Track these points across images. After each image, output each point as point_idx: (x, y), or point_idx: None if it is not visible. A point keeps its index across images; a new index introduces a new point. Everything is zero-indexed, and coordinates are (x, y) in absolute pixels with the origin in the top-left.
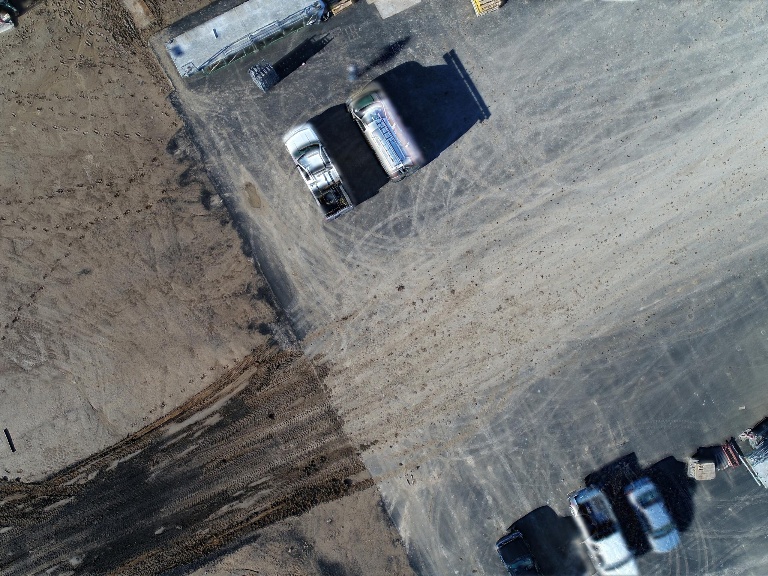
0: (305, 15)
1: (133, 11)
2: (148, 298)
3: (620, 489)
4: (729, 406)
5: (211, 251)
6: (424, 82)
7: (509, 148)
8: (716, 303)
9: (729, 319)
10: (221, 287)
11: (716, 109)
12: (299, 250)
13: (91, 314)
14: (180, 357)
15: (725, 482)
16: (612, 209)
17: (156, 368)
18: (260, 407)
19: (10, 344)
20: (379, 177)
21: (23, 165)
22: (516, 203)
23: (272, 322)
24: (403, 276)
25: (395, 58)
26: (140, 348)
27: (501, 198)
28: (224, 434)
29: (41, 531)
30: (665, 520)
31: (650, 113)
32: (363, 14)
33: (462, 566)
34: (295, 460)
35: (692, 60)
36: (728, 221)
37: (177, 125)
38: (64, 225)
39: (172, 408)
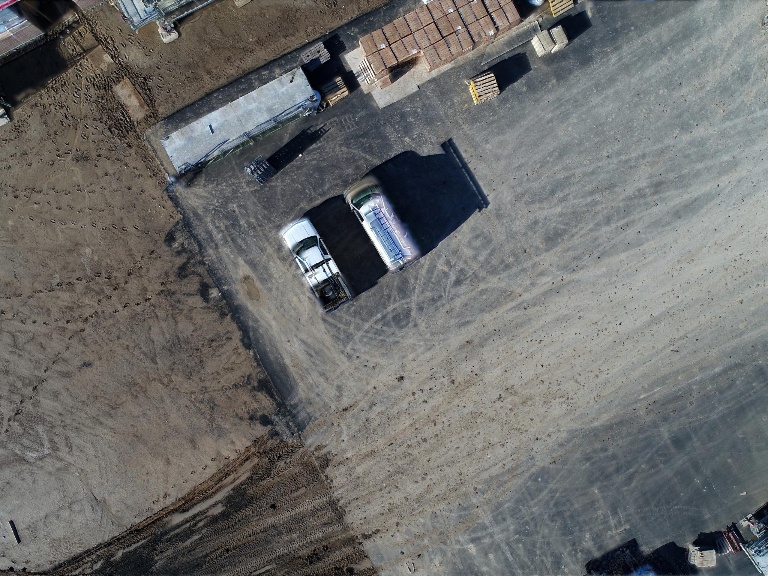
0: (301, 110)
1: (128, 104)
2: (149, 390)
3: (621, 575)
4: (730, 492)
5: (211, 343)
6: (422, 172)
7: (508, 237)
8: (717, 390)
9: (730, 406)
10: (221, 379)
11: (718, 195)
12: (298, 342)
13: (92, 407)
14: (181, 448)
15: (726, 567)
16: (612, 297)
17: (158, 459)
18: (262, 497)
19: (13, 437)
20: (378, 268)
21: (22, 259)
22: (516, 292)
23: (272, 413)
24: (403, 367)
25: (393, 148)
26: (142, 440)
27: (500, 287)
28: (226, 524)
29: None
30: None
31: (651, 200)
32: (360, 104)
33: None
34: (297, 549)
35: (693, 145)
36: (730, 308)
37: (175, 218)
38: (64, 319)
39: (174, 499)
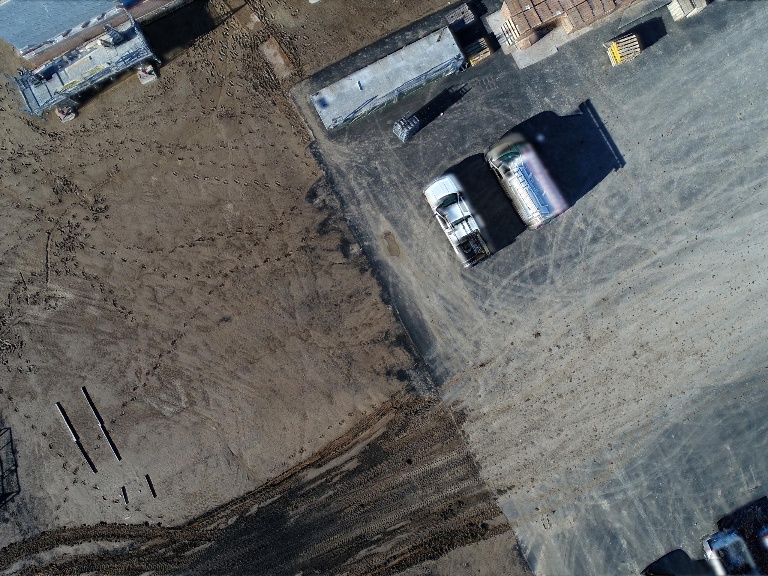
0: (448, 68)
1: (273, 62)
2: (287, 345)
3: (752, 532)
4: None
5: (350, 299)
6: (560, 131)
7: (644, 196)
8: None
9: None
10: (359, 334)
11: None
12: (437, 298)
13: (231, 361)
14: (319, 403)
15: None
16: (745, 256)
17: (295, 414)
18: (398, 453)
19: (151, 391)
20: (516, 225)
21: (164, 214)
22: (651, 251)
23: (410, 369)
24: (540, 323)
25: (532, 108)
26: (279, 394)
27: (636, 246)
28: (362, 479)
29: (182, 575)
30: None
31: None
32: (500, 64)
33: None
34: (432, 505)
35: None
36: None
37: (317, 174)
38: (204, 273)
39: (311, 454)
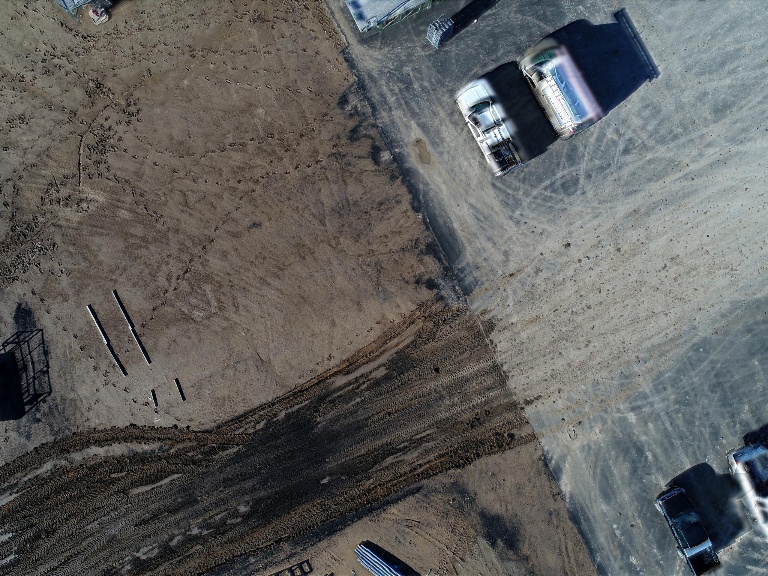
0: None
1: None
2: (317, 252)
3: None
4: None
5: (380, 206)
6: (595, 40)
7: (678, 107)
8: None
9: None
10: (389, 242)
11: None
12: (468, 206)
13: (261, 267)
14: (347, 311)
15: None
16: None
17: (324, 321)
18: (425, 361)
19: (181, 295)
20: (548, 135)
21: (196, 119)
22: (683, 162)
23: (439, 277)
24: (570, 234)
25: (566, 16)
26: (308, 301)
27: (669, 157)
28: (389, 387)
29: (209, 478)
30: None
31: None
32: None
33: (620, 520)
34: (459, 413)
35: None
36: None
37: (349, 81)
38: (235, 179)
39: (339, 361)
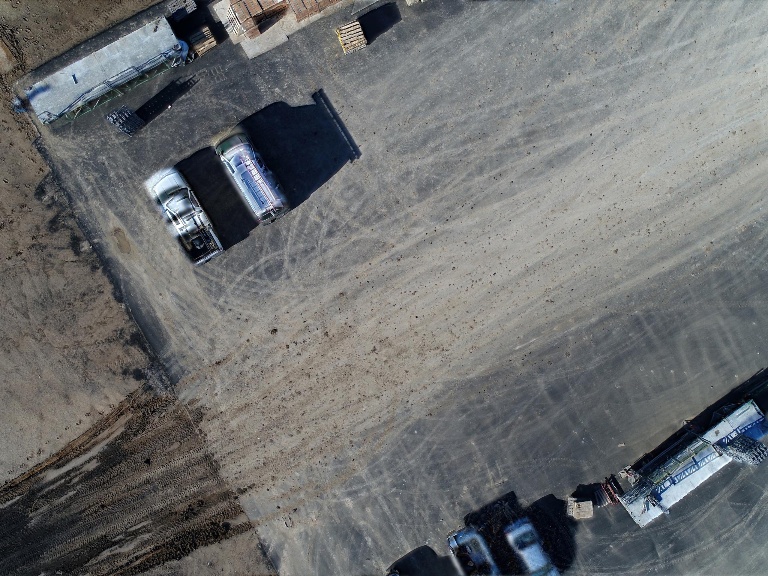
0: (165, 59)
1: None
2: (21, 345)
3: (500, 528)
4: (608, 443)
5: (83, 297)
6: (293, 122)
7: (381, 188)
8: (593, 340)
9: (607, 356)
10: (94, 333)
11: (591, 144)
12: (170, 295)
13: None
14: (55, 404)
15: (606, 519)
16: (486, 248)
17: (31, 415)
18: (136, 452)
19: None
20: (249, 220)
21: None
22: (389, 243)
23: (146, 367)
24: (276, 319)
25: (263, 99)
26: (15, 395)
27: (373, 239)
28: (101, 480)
29: None
30: (545, 558)
31: (524, 149)
32: (229, 54)
33: None
34: (173, 504)
35: (566, 94)
36: (604, 257)
37: (44, 171)
38: None
39: (48, 455)
